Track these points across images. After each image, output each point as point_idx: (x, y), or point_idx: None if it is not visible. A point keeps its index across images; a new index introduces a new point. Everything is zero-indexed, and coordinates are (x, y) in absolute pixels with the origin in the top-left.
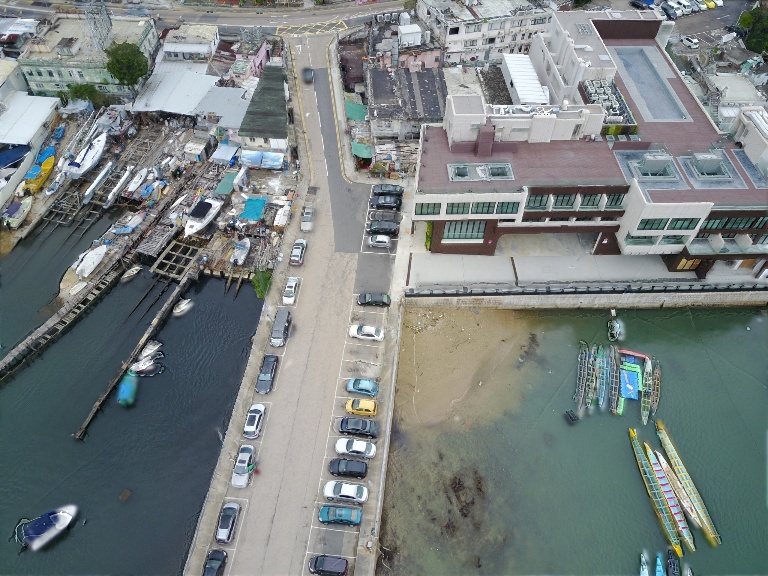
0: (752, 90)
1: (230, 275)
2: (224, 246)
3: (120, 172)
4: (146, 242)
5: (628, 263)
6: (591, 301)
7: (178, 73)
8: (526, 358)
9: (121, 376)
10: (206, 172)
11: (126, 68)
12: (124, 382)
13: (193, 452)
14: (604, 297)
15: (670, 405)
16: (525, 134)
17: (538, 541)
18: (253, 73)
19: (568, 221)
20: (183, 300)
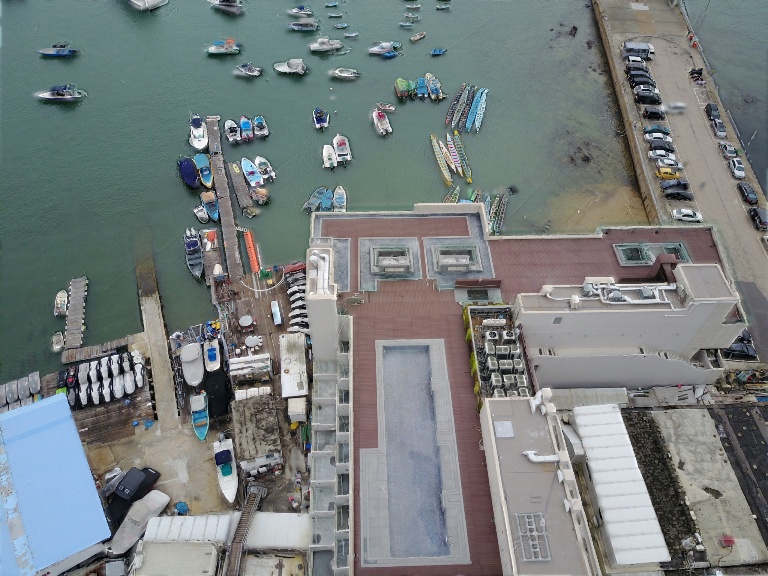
0: None
1: None
2: None
3: None
4: None
5: None
6: None
7: None
8: (544, 228)
9: None
10: None
11: None
12: None
13: (764, 185)
14: None
15: None
16: None
17: (535, 140)
18: None
19: None
20: None
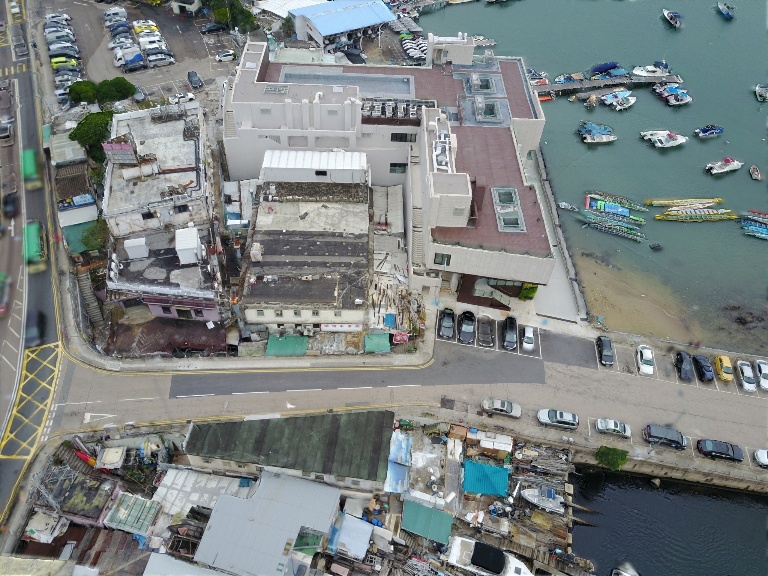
0: (303, 51)
1: (572, 519)
2: (527, 530)
3: None
4: None
5: None
6: None
7: None
8: (608, 263)
9: None
10: None
11: None
12: None
13: None
14: None
15: None
16: None
17: (759, 283)
18: None
19: None
20: None
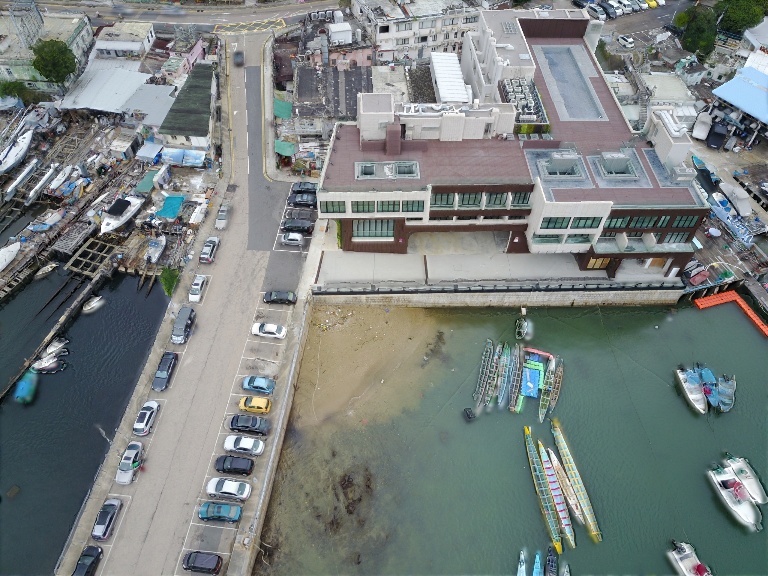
0: (683, 89)
1: (144, 273)
2: (141, 244)
3: (45, 169)
4: (63, 239)
5: (540, 262)
6: (501, 299)
7: (109, 70)
8: (431, 356)
9: (23, 373)
10: (131, 170)
11: (52, 65)
12: (25, 379)
13: (89, 449)
14: (513, 295)
15: (569, 403)
16: (436, 133)
17: (421, 538)
18: (187, 71)
19: (476, 220)
20: (94, 297)
